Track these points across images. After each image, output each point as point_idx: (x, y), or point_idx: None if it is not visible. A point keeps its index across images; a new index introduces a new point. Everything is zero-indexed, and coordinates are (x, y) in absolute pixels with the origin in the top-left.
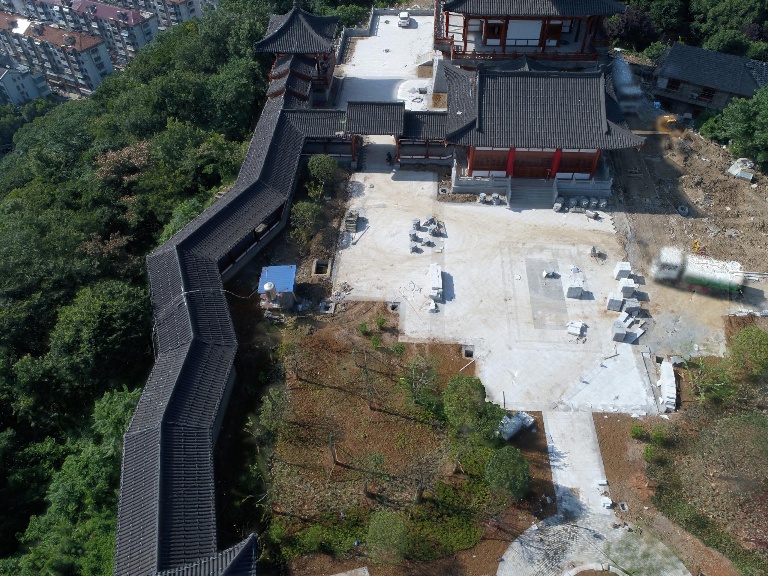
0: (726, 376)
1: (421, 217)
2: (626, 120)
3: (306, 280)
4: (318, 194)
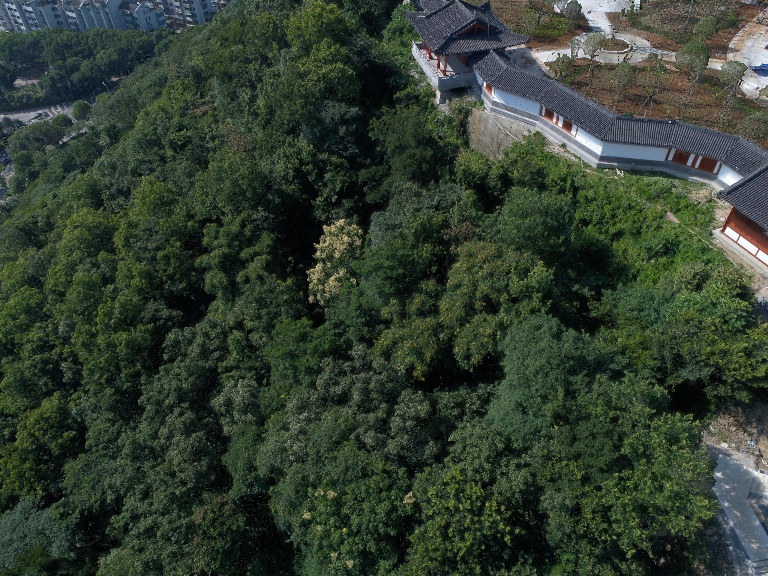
0: (662, 1)
1: None
2: None
3: None
4: None
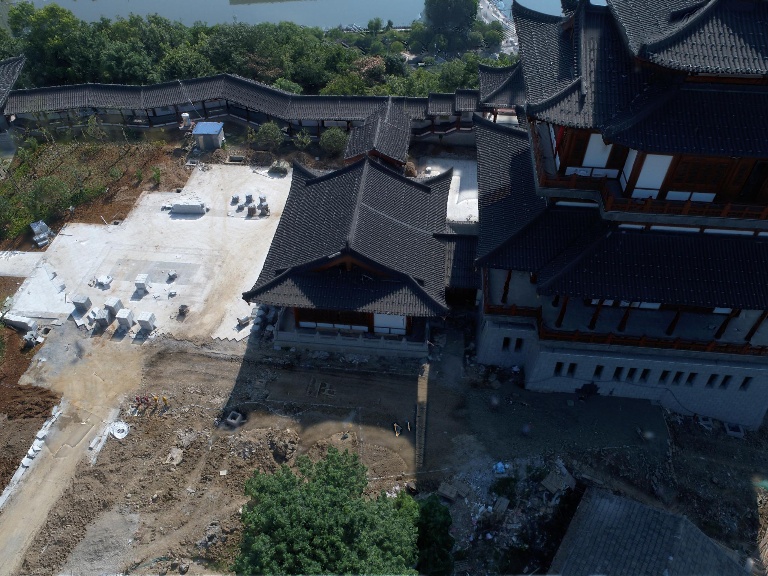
0: None
1: (277, 206)
2: (455, 413)
3: None
4: (306, 143)
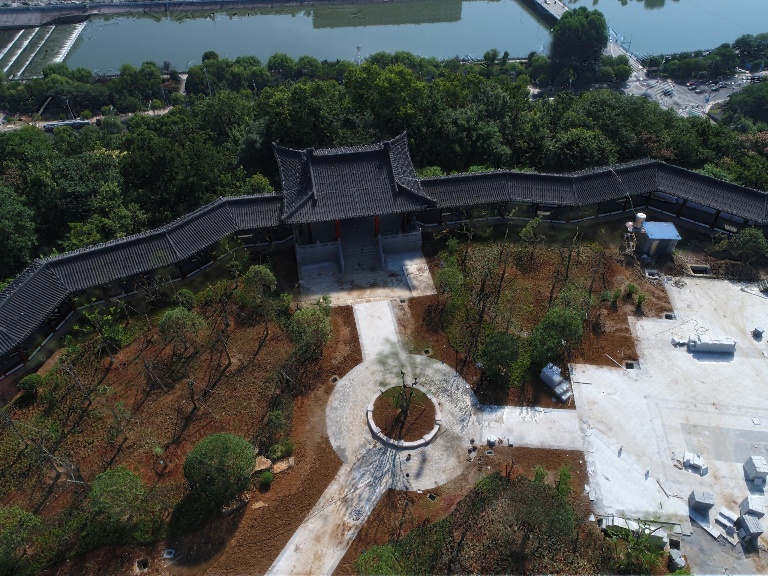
0: None
1: None
2: None
3: (677, 258)
4: None
